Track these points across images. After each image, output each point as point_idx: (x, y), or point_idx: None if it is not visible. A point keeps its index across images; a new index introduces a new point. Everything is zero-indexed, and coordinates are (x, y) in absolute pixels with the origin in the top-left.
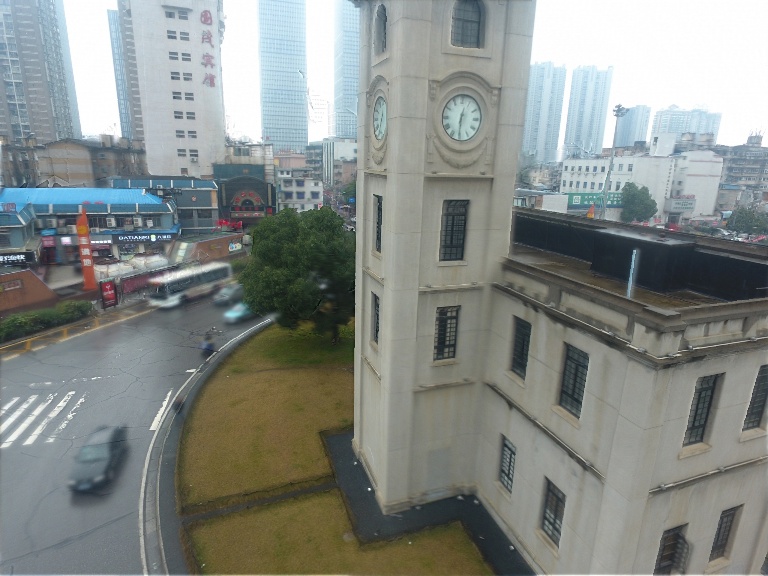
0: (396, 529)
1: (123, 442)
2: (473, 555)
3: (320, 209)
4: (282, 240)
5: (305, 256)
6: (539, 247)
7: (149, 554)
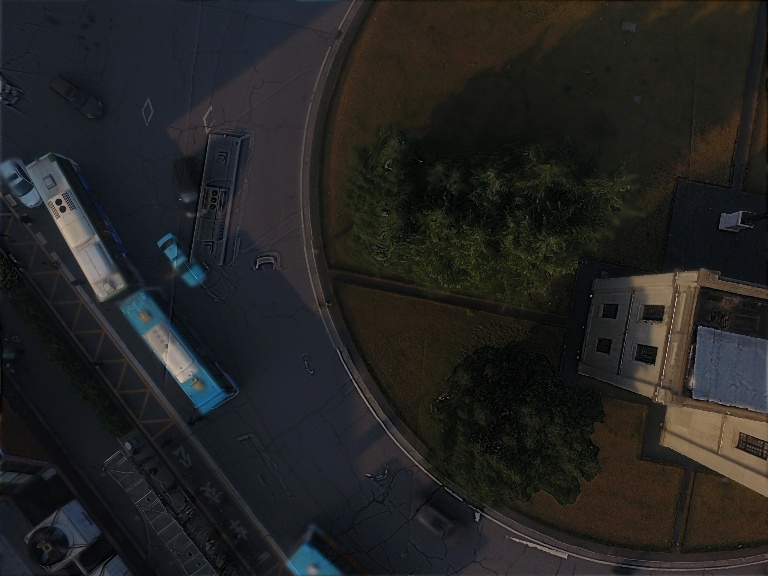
0: None
1: (576, 575)
2: None
3: None
4: None
5: None
6: None
7: (685, 567)
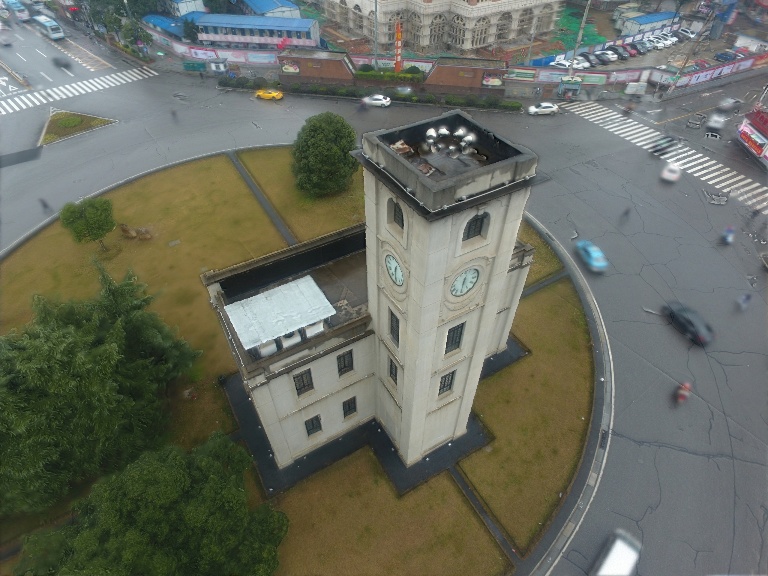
0: (474, 425)
1: None
2: (477, 387)
3: (166, 478)
4: (172, 569)
5: (242, 508)
6: (316, 266)
7: (545, 570)
